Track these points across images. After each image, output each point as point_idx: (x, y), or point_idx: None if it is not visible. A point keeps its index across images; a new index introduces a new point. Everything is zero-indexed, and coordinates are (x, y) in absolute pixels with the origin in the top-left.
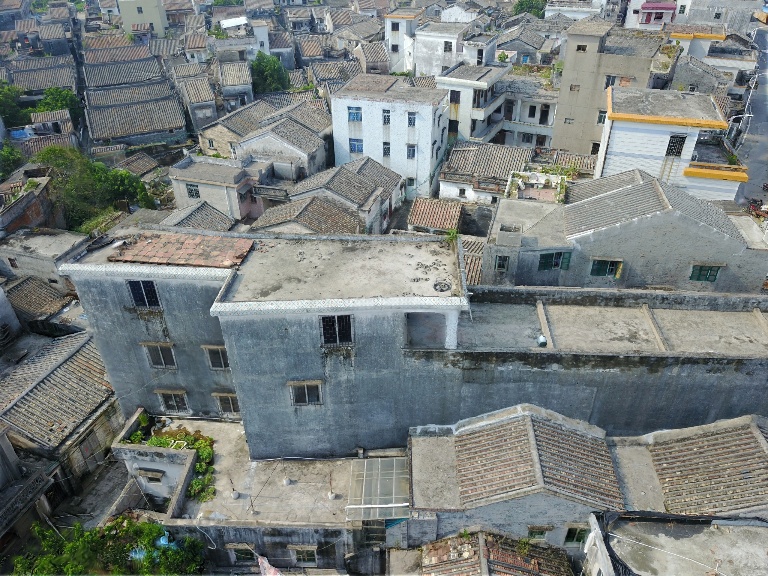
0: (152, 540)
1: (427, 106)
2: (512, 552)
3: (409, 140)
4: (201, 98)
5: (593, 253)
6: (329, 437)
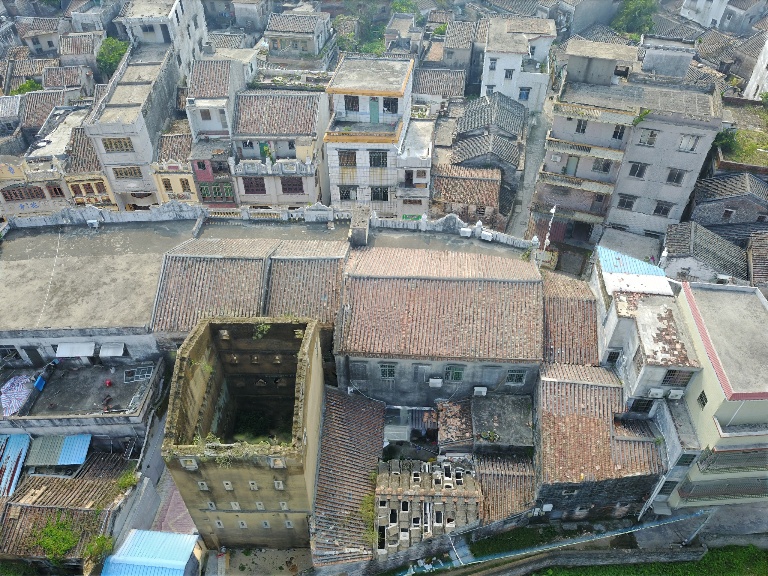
0: (119, 52)
1: None
2: None
3: None
4: (545, 2)
5: None
6: None
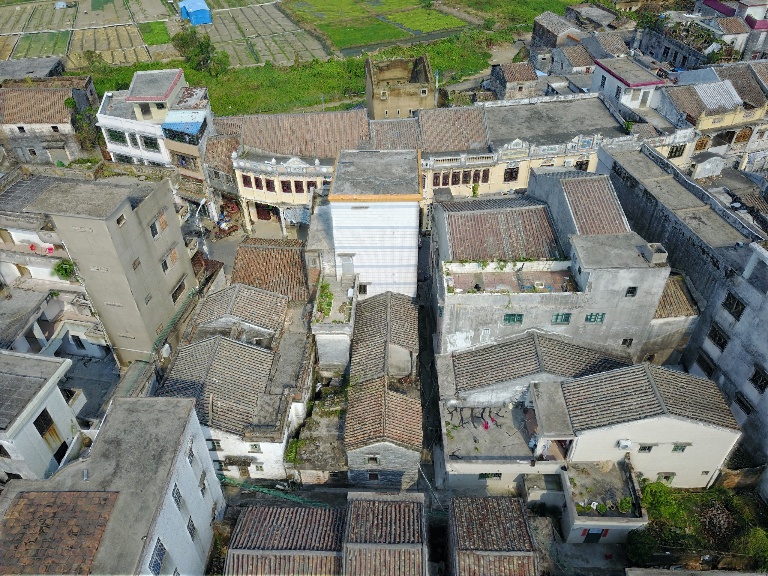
0: None
1: (192, 417)
2: None
3: (198, 479)
4: None
5: None
6: None
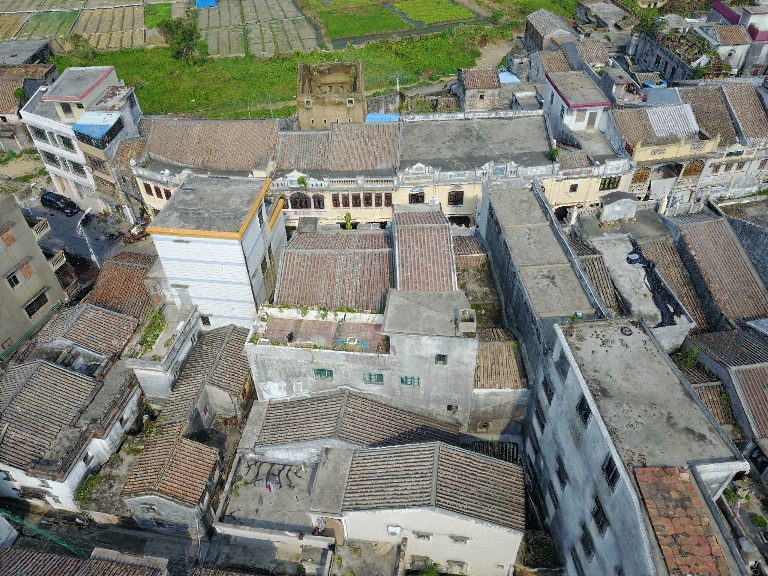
0: None
1: None
2: None
3: None
4: None
5: None
6: None
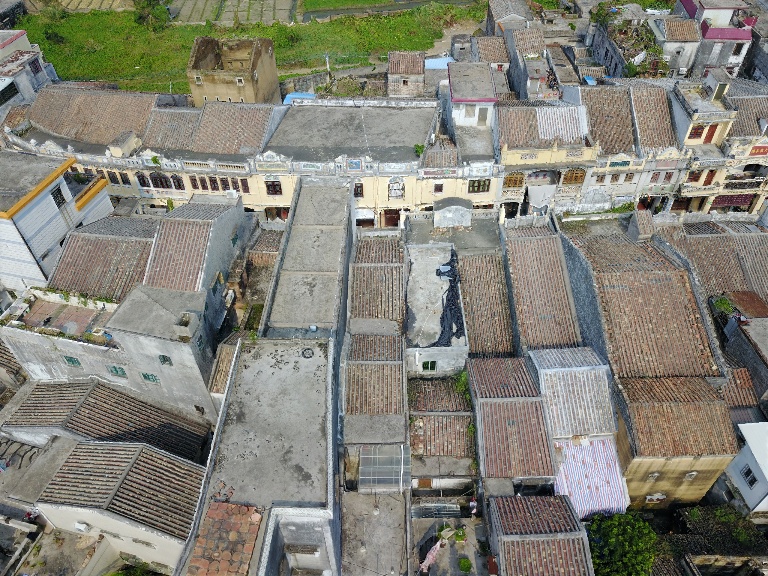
0: None
1: None
2: (416, 402)
3: None
4: None
5: (209, 284)
6: (338, 505)
